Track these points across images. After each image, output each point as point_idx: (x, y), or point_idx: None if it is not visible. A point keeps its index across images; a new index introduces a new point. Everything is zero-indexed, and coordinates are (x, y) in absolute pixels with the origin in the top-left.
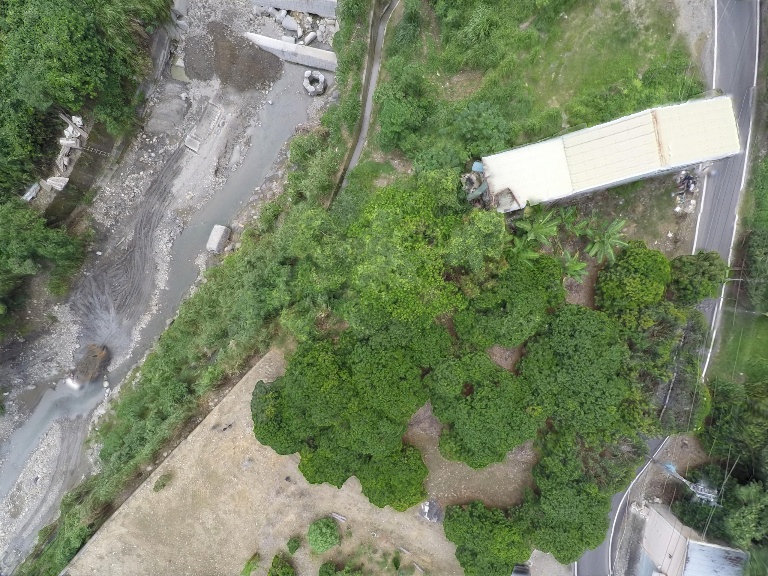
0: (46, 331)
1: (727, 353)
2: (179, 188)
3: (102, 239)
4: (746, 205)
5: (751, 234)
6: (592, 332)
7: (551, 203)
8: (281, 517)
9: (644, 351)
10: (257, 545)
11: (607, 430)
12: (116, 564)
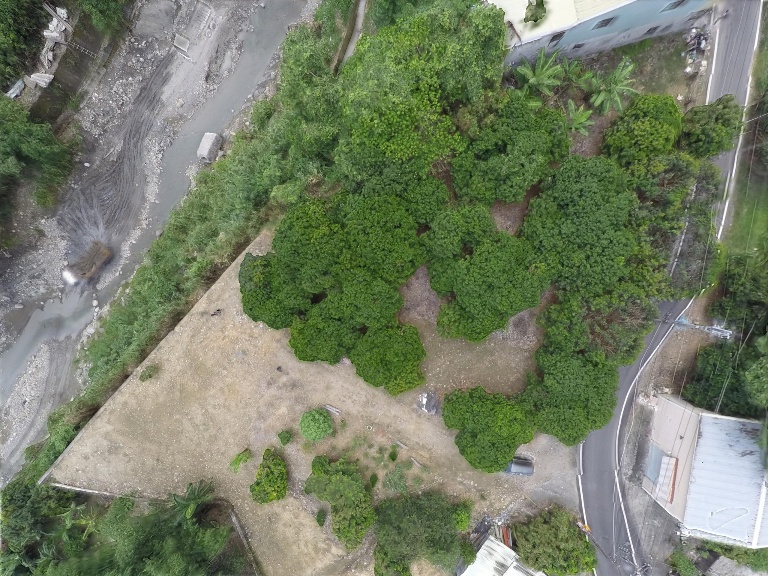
0: (33, 246)
1: (740, 226)
2: (169, 95)
3: (90, 150)
4: (760, 65)
5: (766, 91)
6: (598, 174)
7: (554, 50)
8: (273, 410)
9: (654, 202)
10: (248, 441)
11: (614, 291)
12: (102, 464)
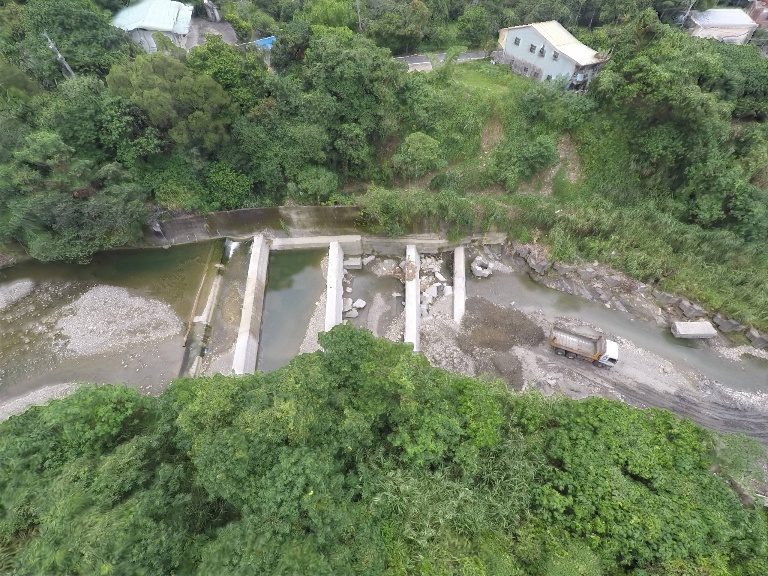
0: None
1: None
2: (665, 385)
3: None
4: None
5: None
6: None
7: None
8: None
9: None
10: None
11: None
12: None
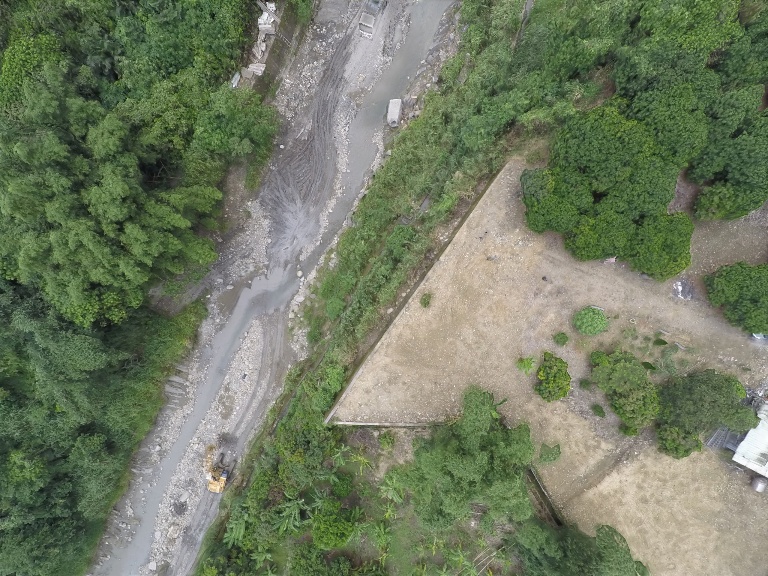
0: (241, 229)
1: None
2: (350, 72)
3: (284, 132)
4: None
5: None
6: None
7: None
8: (541, 319)
9: None
10: (520, 351)
11: None
12: (383, 395)
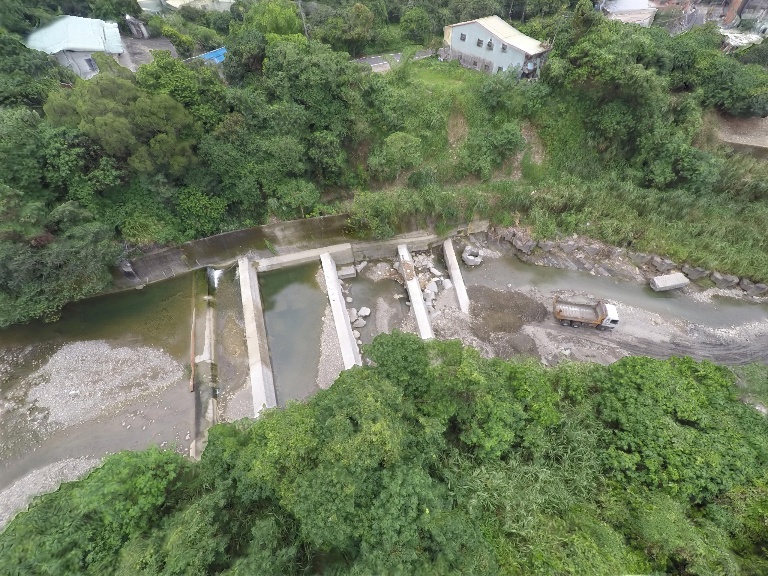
0: None
1: None
2: (660, 335)
3: None
4: None
5: None
6: None
7: None
8: None
9: None
10: None
11: None
12: None
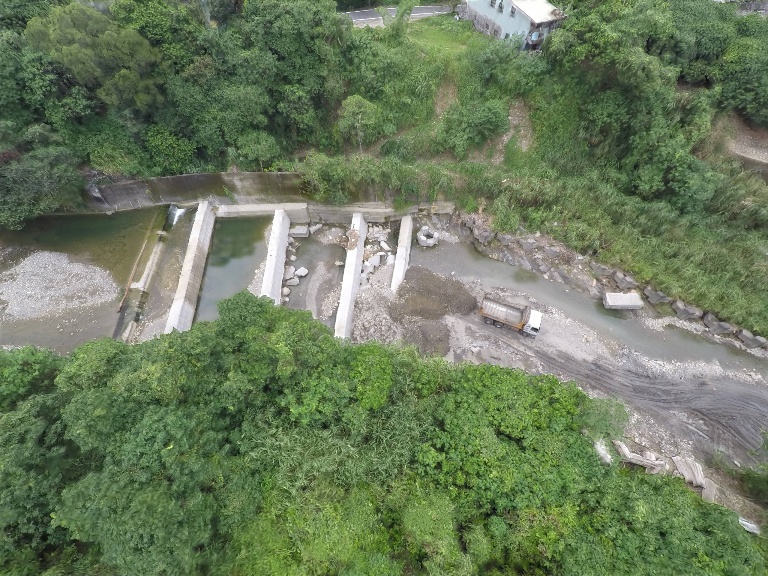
0: None
1: None
2: (584, 353)
3: None
4: None
5: None
6: None
7: None
8: None
9: None
10: None
11: None
12: None
